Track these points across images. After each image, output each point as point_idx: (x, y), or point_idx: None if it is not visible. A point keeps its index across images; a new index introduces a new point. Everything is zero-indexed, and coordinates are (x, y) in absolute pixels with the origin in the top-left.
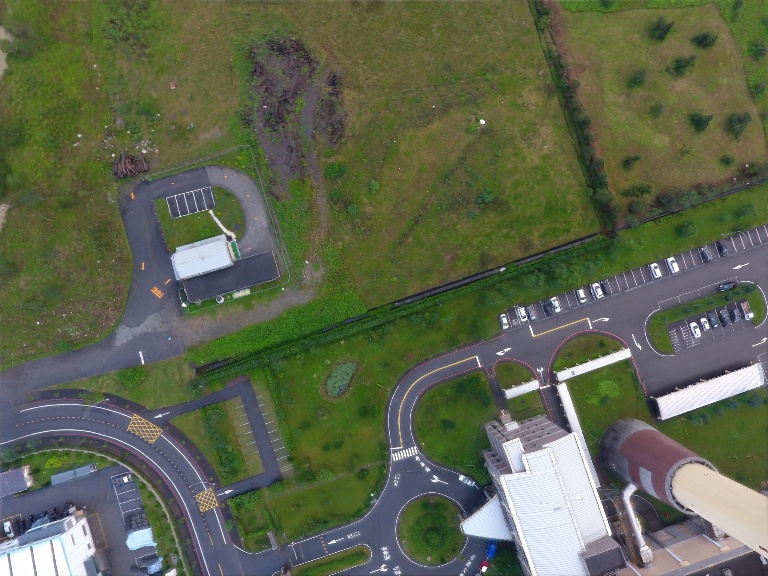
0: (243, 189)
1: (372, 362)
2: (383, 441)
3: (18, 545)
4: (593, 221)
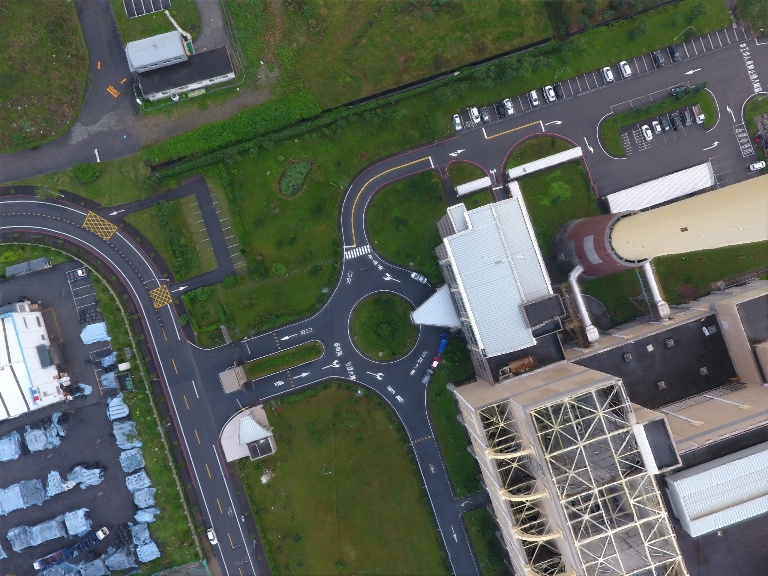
0: None
1: (326, 161)
2: (336, 237)
3: None
4: (546, 25)
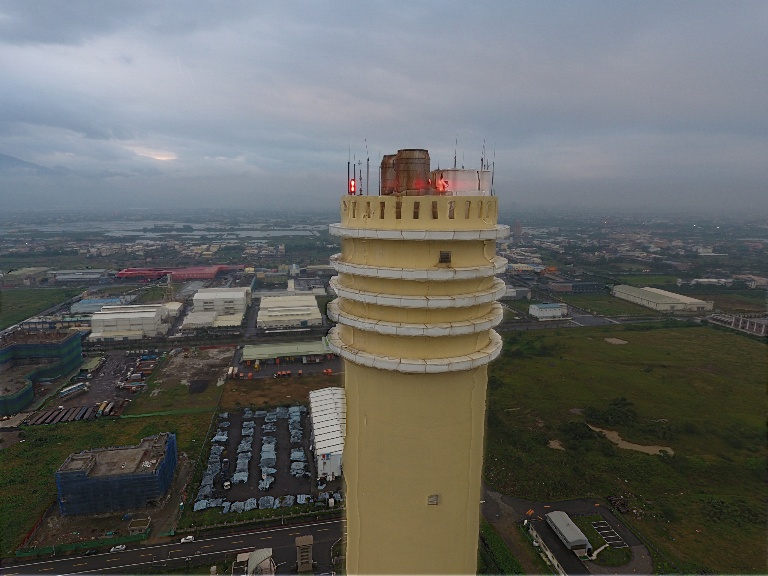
0: (639, 567)
1: None
2: None
3: None
4: None
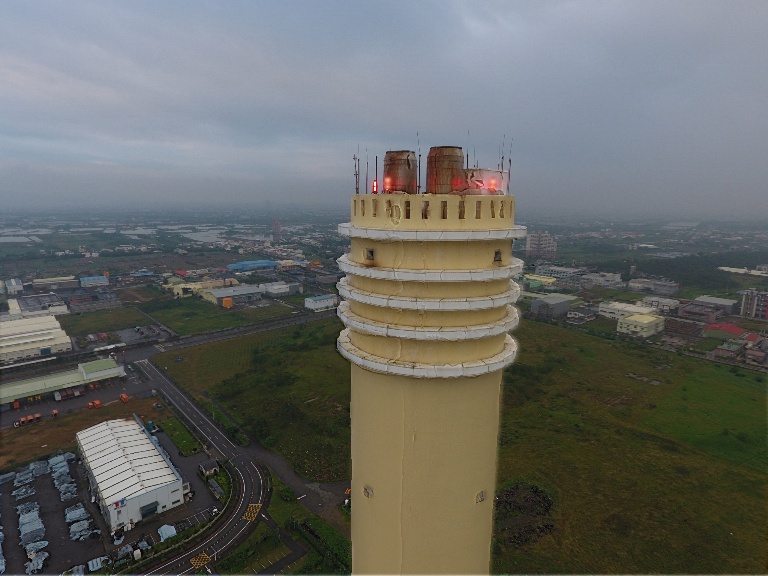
0: None
1: None
2: None
3: (175, 468)
4: None
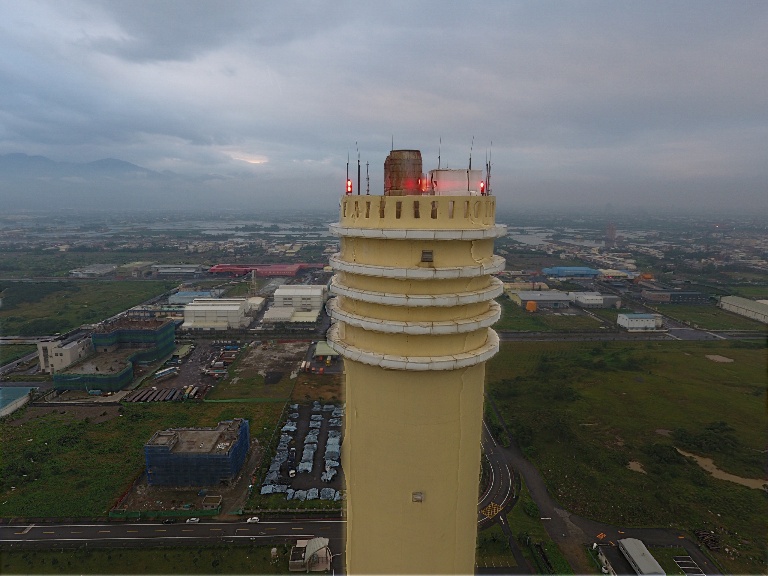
0: None
1: None
2: None
3: None
4: None
